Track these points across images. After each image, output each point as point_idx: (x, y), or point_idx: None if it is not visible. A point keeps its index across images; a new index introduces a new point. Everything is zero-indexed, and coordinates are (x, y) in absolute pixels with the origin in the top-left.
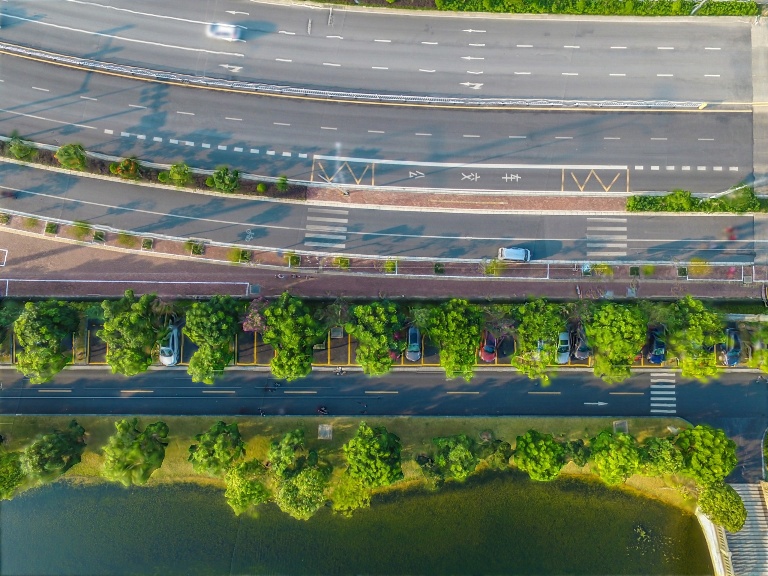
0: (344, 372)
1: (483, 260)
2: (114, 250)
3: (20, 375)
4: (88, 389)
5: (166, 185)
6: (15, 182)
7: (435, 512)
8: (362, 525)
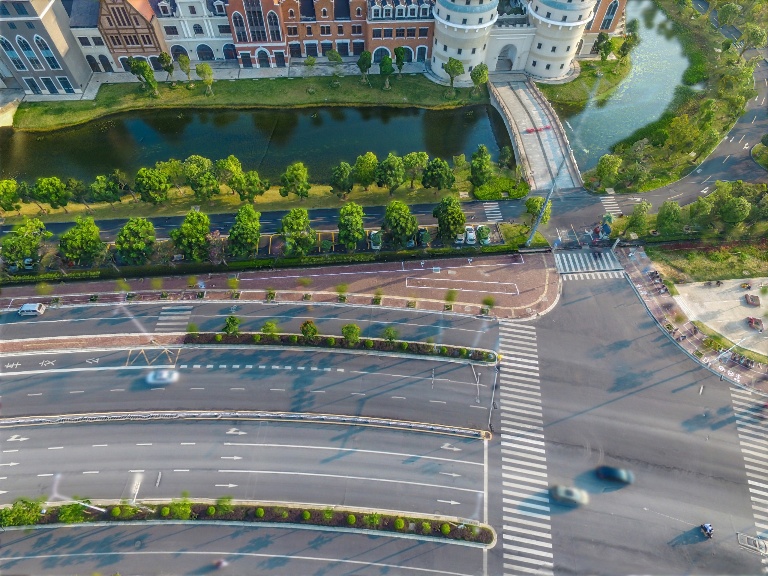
0: None
1: (59, 307)
2: (332, 292)
3: None
4: None
5: None
6: (408, 329)
7: None
8: None
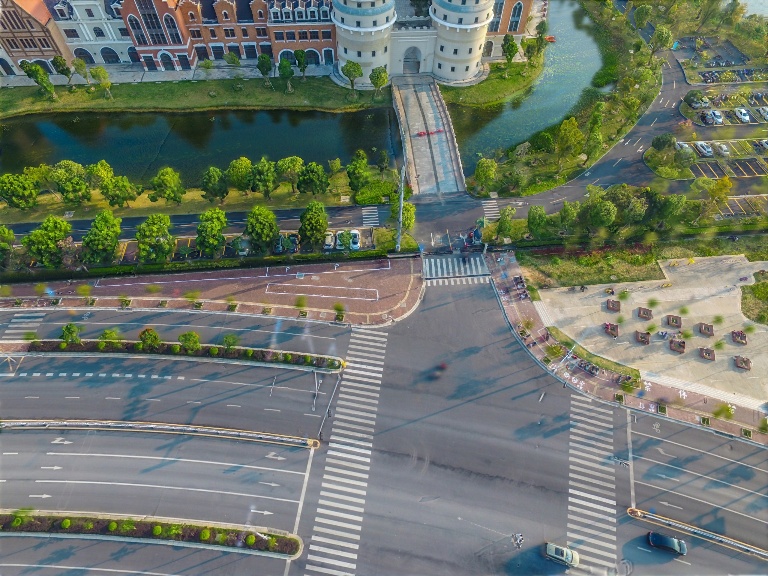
0: None
1: None
2: (189, 299)
3: None
4: None
5: None
6: (259, 336)
7: None
8: None
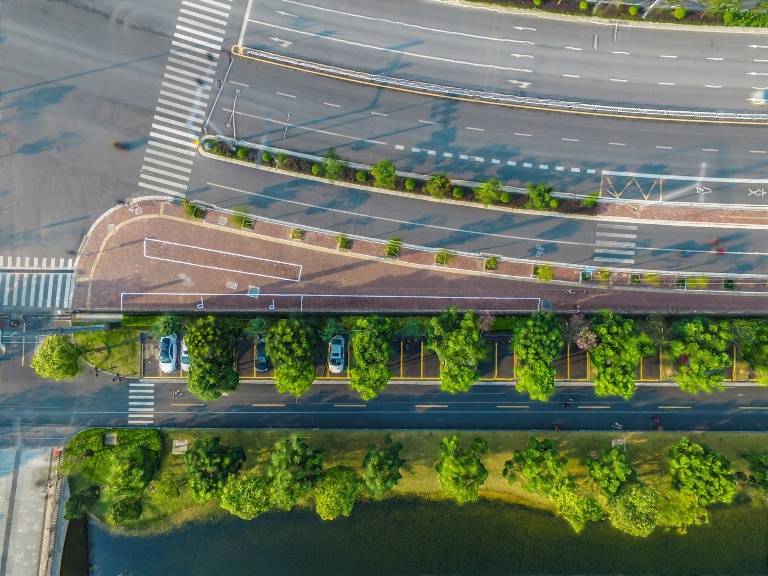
0: (637, 387)
1: None
2: (407, 265)
3: (316, 390)
4: (383, 404)
5: (458, 201)
6: (308, 198)
7: (721, 526)
8: (649, 539)
